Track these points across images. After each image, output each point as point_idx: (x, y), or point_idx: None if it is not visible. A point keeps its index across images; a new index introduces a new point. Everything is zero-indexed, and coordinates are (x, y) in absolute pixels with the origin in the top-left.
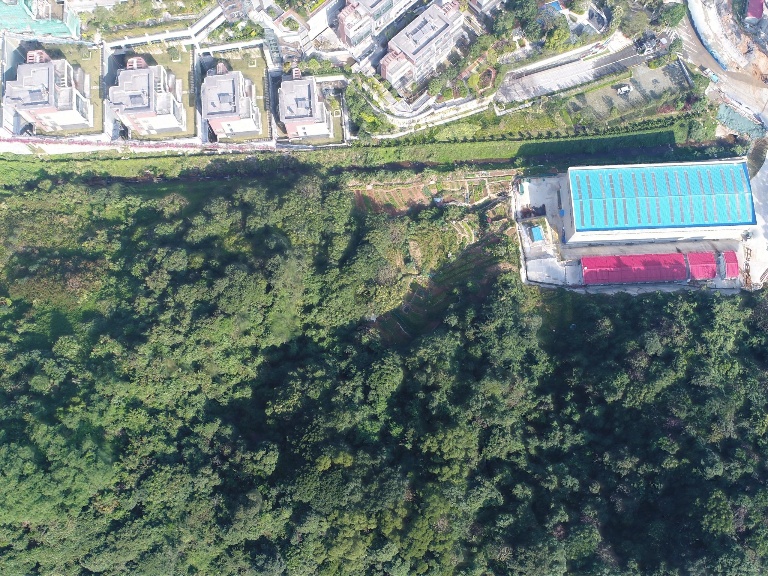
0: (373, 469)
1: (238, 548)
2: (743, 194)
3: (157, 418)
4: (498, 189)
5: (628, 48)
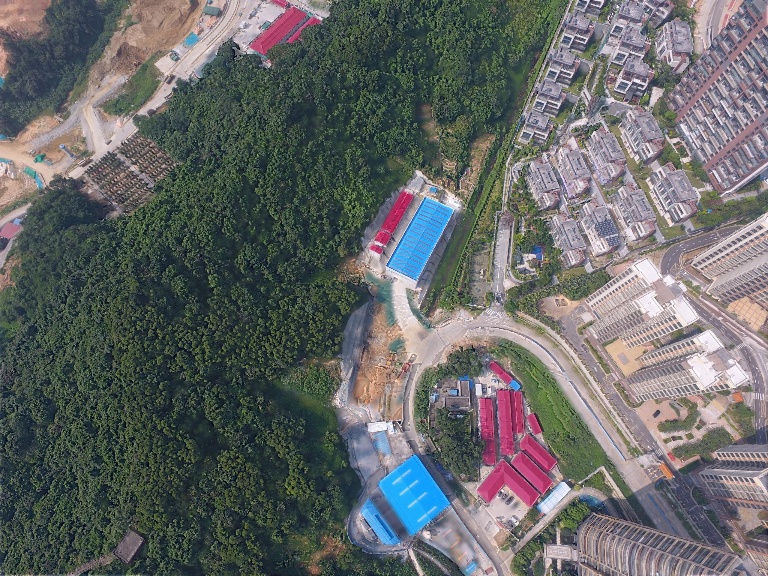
0: (380, 48)
1: (380, 8)
2: (403, 269)
3: (433, 8)
4: (462, 194)
5: (503, 289)
